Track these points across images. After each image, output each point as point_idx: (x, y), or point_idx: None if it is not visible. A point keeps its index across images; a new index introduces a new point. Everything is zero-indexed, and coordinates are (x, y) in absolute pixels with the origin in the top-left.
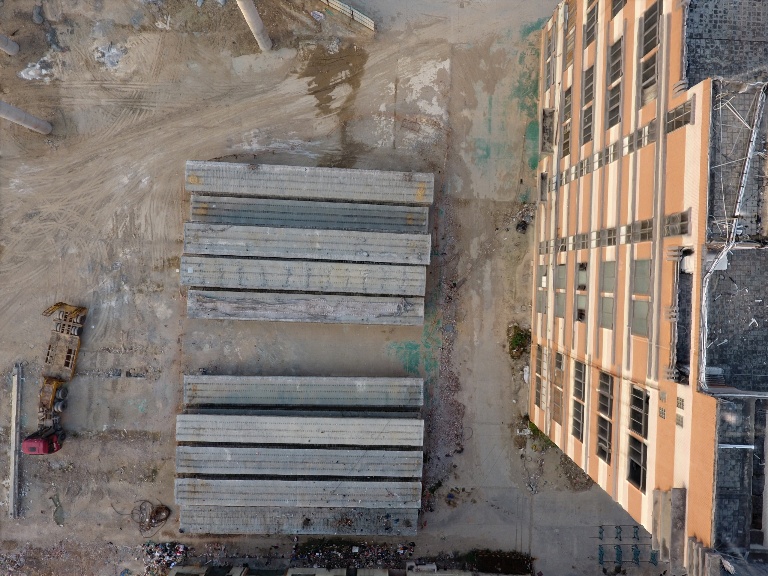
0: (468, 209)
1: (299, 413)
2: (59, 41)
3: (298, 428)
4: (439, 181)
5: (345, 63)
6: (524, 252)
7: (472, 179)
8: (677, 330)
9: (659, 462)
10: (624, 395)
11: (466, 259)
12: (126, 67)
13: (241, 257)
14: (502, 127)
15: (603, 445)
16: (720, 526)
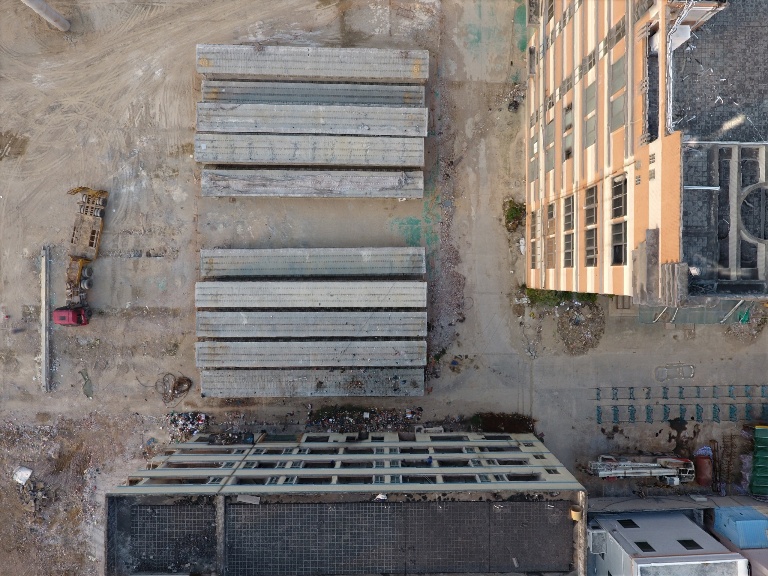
0: (462, 91)
1: None
2: None
3: (309, 292)
4: (434, 65)
5: None
6: (516, 130)
7: (465, 63)
8: (648, 100)
9: (637, 225)
10: (606, 192)
11: (462, 138)
12: None
13: (250, 133)
14: (492, 13)
15: (591, 256)
16: (691, 261)
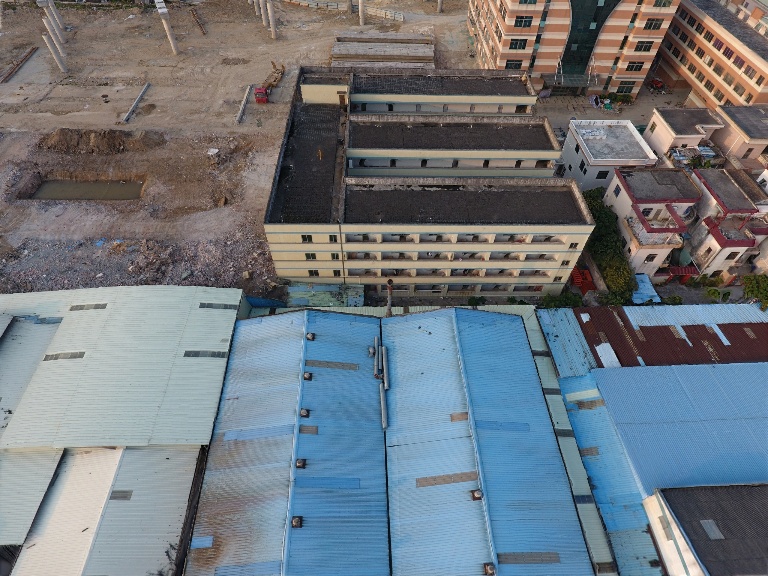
0: None
1: None
2: (284, 24)
3: None
4: None
5: (393, 27)
6: None
7: (448, 47)
8: None
9: None
10: None
11: (450, 63)
12: (308, 28)
13: None
14: None
15: None
16: None
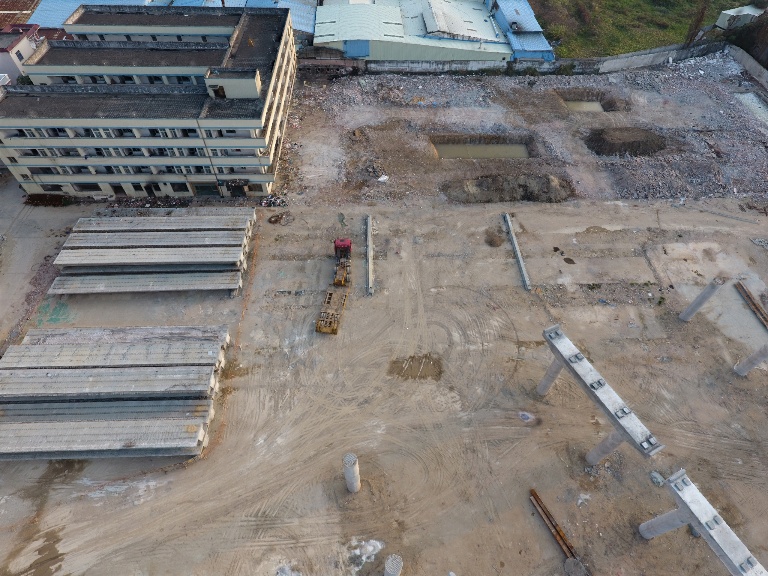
0: None
1: (156, 269)
2: None
3: (152, 256)
4: None
5: None
6: None
7: None
8: None
9: None
10: None
11: None
12: (268, 568)
13: (164, 366)
14: None
15: None
16: None
